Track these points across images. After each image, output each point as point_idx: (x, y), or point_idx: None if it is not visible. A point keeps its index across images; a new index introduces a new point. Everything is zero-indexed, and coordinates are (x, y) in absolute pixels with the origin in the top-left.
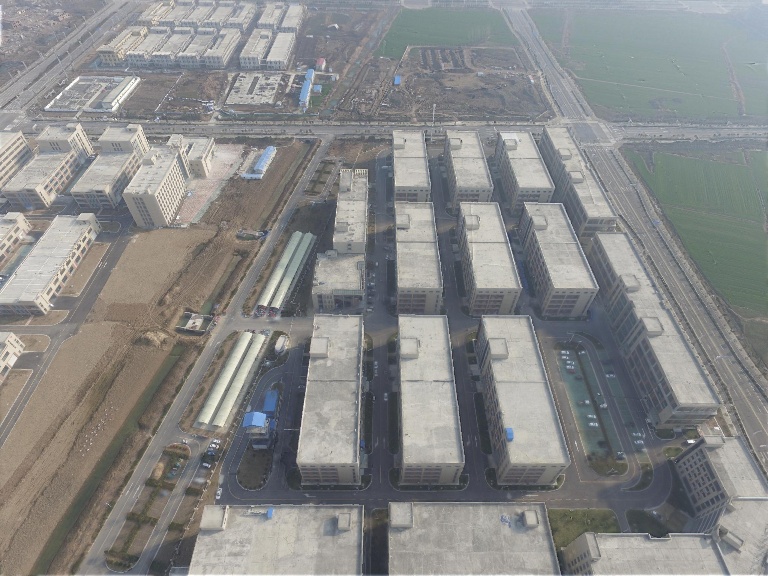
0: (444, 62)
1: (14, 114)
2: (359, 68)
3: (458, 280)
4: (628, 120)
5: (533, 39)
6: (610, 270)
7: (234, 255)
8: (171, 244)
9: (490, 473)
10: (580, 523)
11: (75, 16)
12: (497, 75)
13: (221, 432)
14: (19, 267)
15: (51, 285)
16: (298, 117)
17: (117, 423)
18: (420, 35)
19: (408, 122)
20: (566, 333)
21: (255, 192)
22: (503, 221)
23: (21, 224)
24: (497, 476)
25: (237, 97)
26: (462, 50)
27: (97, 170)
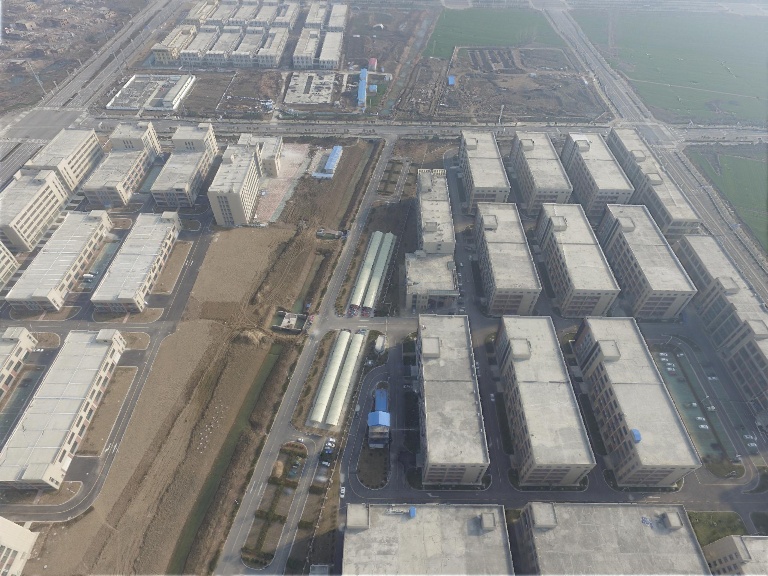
0: (494, 63)
1: (76, 112)
2: (410, 68)
3: (545, 281)
4: (688, 122)
5: (579, 40)
6: (703, 272)
7: (316, 254)
8: (253, 243)
9: (608, 474)
10: (706, 525)
11: (120, 14)
12: (549, 76)
13: (334, 431)
14: (111, 265)
15: (145, 283)
16: (358, 117)
17: (229, 421)
18: (466, 35)
19: (468, 122)
20: (661, 335)
21: (328, 191)
22: (587, 222)
23: (105, 222)
24: (616, 477)
25: (294, 96)
26: (510, 51)
27: (173, 168)
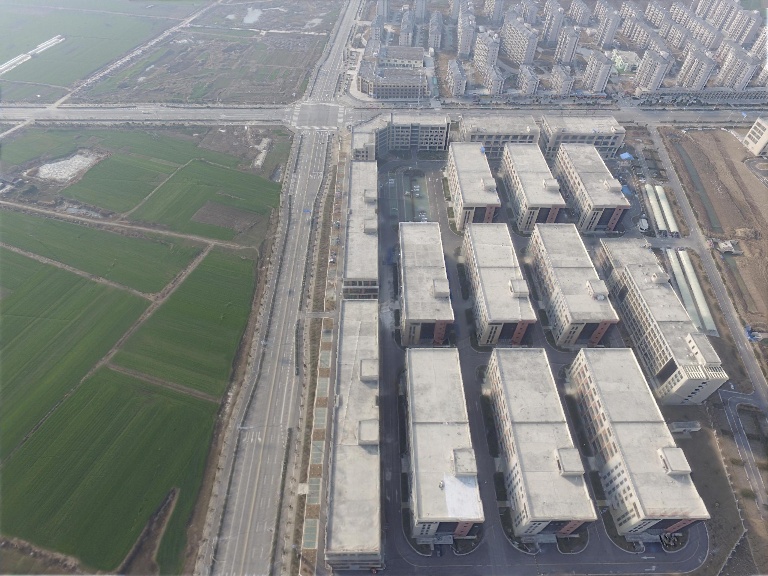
0: None
1: None
2: None
3: None
4: None
5: None
6: None
7: (760, 313)
8: None
9: None
10: (437, 156)
11: None
12: None
13: None
14: None
15: None
16: None
17: None
18: None
19: None
20: None
21: None
22: None
23: None
24: None
25: None
26: None
27: None
